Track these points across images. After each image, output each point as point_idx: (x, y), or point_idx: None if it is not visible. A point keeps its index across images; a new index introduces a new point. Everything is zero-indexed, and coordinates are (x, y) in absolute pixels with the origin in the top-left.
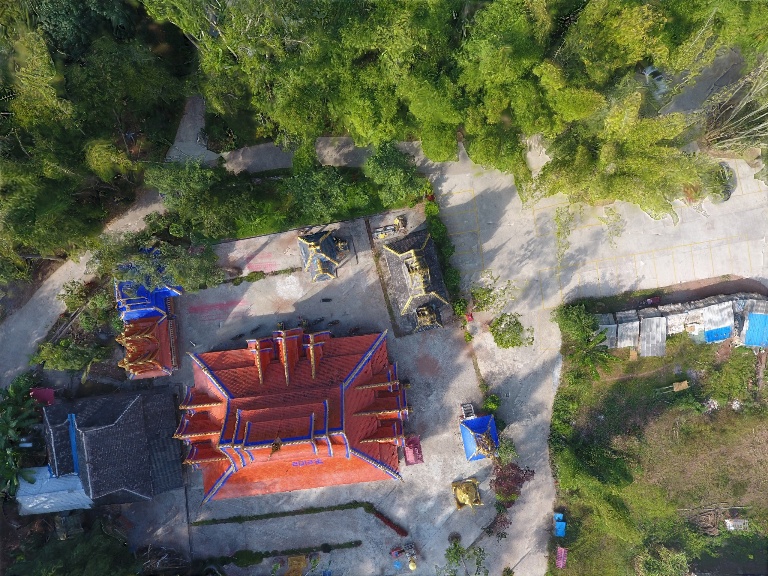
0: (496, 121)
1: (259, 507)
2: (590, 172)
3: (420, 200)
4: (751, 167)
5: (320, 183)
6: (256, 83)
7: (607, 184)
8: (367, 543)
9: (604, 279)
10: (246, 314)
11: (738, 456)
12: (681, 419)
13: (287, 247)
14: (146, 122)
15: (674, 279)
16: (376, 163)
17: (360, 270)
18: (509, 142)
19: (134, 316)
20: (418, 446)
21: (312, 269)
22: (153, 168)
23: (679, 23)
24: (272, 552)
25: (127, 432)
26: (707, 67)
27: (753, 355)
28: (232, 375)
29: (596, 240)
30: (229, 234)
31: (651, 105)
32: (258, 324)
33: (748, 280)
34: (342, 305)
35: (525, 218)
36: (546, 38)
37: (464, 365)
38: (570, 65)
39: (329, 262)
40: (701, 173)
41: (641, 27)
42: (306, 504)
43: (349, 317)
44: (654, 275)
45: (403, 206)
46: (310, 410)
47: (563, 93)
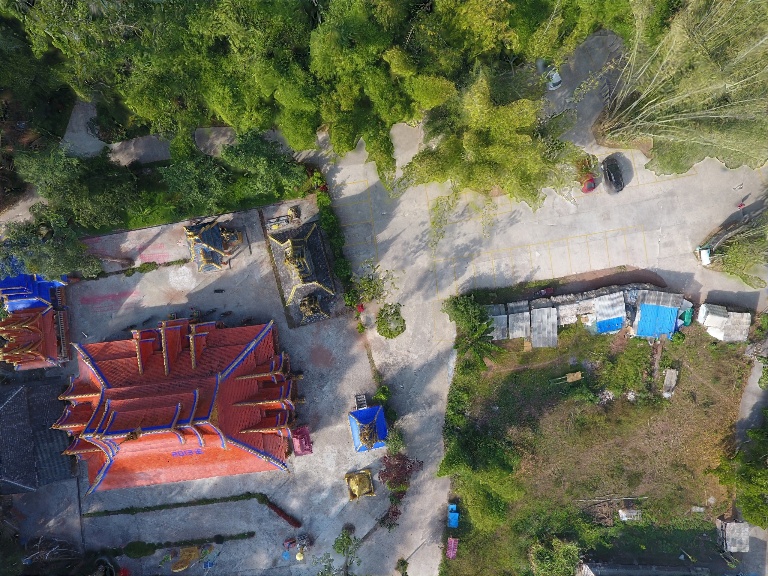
0: (350, 108)
1: (152, 498)
2: (460, 161)
3: (313, 191)
4: (647, 157)
5: (194, 172)
6: (84, 68)
7: (467, 172)
8: (260, 534)
9: (499, 270)
10: (138, 305)
11: (633, 447)
12: (576, 410)
13: (180, 238)
14: (33, 112)
15: (569, 270)
16: (229, 150)
17: (253, 261)
18: (371, 130)
19: (18, 307)
20: (306, 437)
21: (198, 259)
22: (21, 157)
23: (541, 10)
24: (165, 543)
25: (9, 423)
26: (570, 54)
27: (648, 346)
28: (113, 366)
29: (491, 231)
30: (121, 225)
31: (516, 93)
32: (150, 315)
33: (644, 271)
34: (235, 296)
35: (419, 209)
36: (394, 24)
37: (358, 356)
38: (424, 52)
39: (215, 252)
40: (569, 161)
41: (485, 13)
42: (199, 495)
43: (242, 308)
44: (549, 266)
45: (296, 197)
46: (180, 400)
47: (418, 80)
